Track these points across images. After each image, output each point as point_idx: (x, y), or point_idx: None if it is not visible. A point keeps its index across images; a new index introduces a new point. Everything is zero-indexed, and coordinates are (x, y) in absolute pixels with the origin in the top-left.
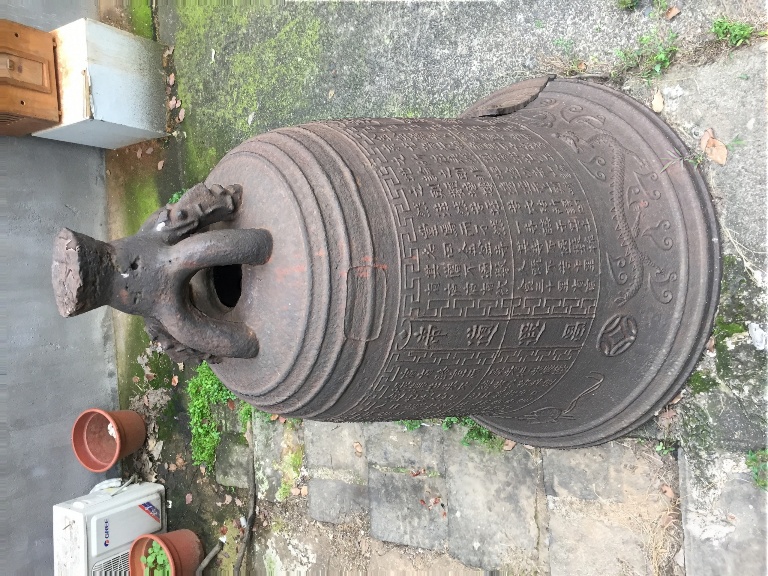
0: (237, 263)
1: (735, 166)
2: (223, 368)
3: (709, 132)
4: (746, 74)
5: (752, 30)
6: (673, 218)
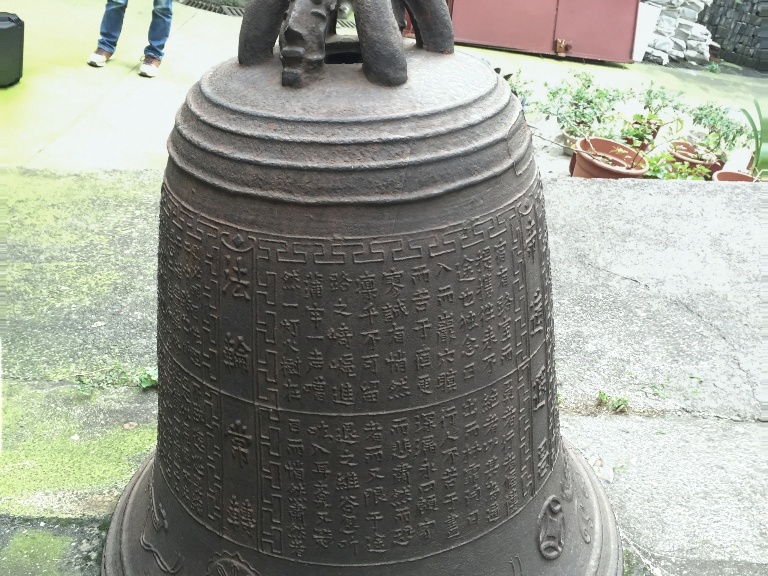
0: (436, 21)
1: (622, 486)
2: (291, 97)
3: (596, 456)
4: (626, 430)
5: (629, 406)
6: (585, 481)
